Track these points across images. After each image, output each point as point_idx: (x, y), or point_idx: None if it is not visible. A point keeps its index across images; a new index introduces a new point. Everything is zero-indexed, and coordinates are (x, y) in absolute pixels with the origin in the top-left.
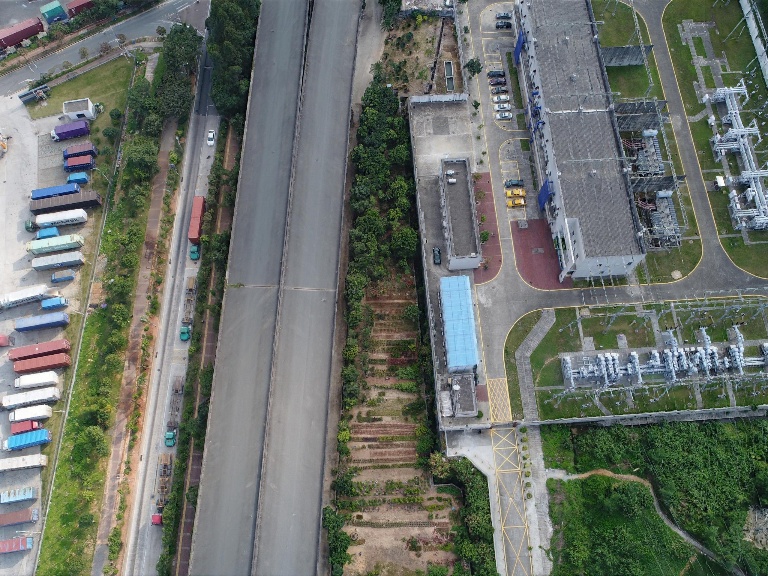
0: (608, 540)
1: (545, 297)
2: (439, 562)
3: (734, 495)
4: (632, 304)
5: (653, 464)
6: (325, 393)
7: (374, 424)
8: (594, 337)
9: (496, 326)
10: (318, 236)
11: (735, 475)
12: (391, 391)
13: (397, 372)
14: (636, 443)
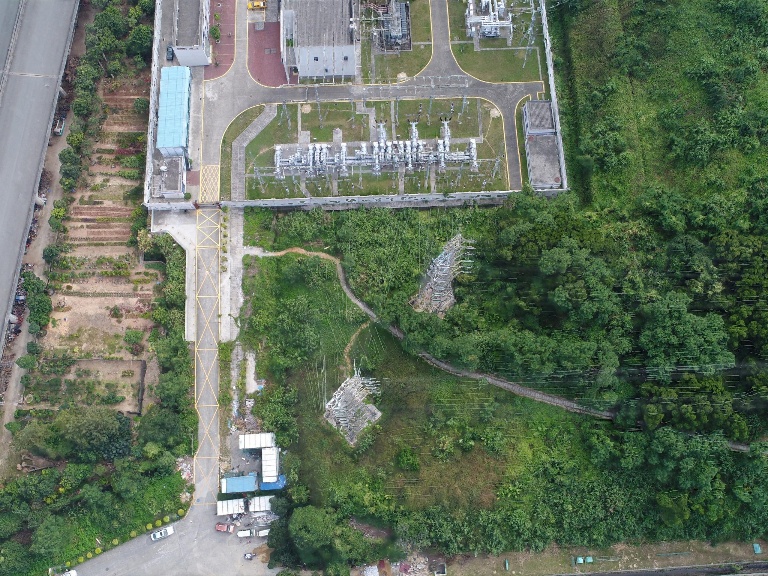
0: (289, 308)
1: (270, 93)
2: (138, 328)
3: (410, 269)
4: (321, 84)
5: (341, 242)
6: (36, 169)
7: (95, 207)
8: (311, 131)
9: (218, 118)
10: (49, 27)
11: (414, 252)
12: (115, 178)
13: (122, 160)
14: (331, 224)
